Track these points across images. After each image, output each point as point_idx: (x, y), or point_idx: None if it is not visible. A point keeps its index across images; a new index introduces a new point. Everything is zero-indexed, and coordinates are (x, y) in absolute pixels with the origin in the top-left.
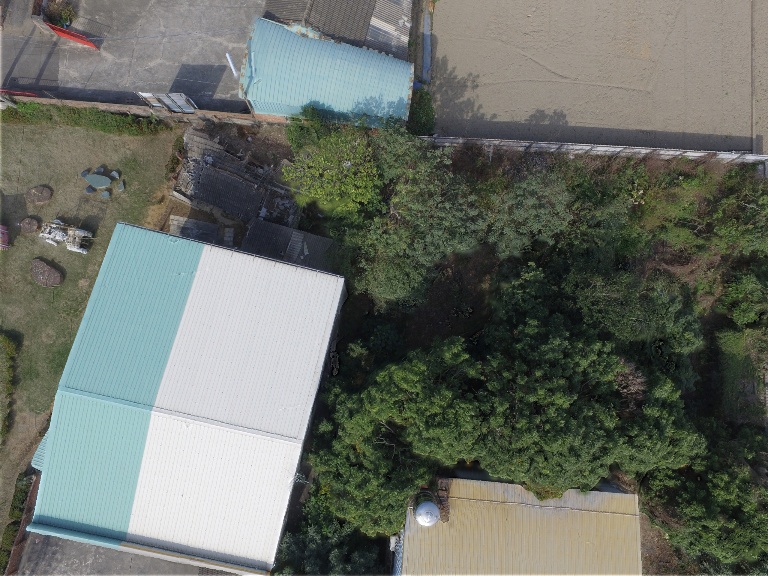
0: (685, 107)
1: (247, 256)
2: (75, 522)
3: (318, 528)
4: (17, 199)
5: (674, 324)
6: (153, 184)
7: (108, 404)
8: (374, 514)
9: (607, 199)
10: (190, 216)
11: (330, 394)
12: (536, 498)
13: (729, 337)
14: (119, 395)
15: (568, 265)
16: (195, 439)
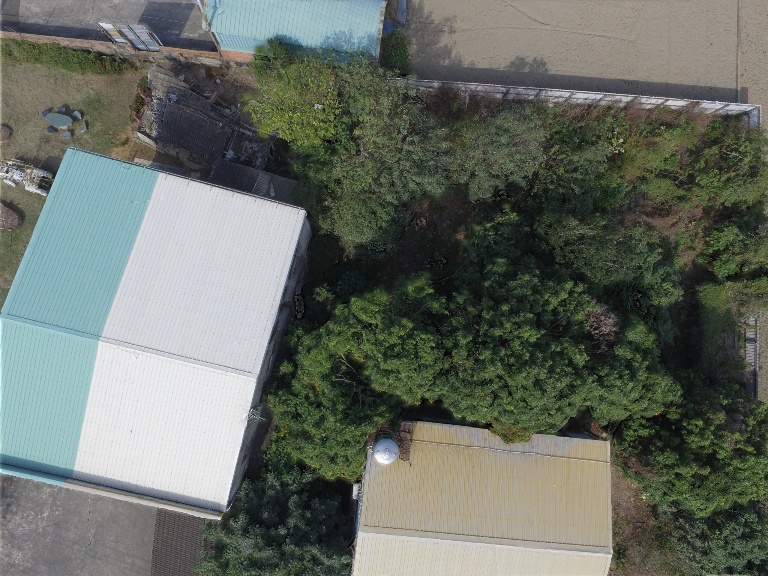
0: (668, 57)
1: (204, 185)
2: (18, 458)
3: (278, 474)
4: None
5: (652, 274)
6: (117, 125)
7: (53, 333)
8: (330, 450)
9: (585, 145)
10: (155, 159)
11: (293, 336)
12: (503, 443)
13: (709, 290)
14: (65, 324)
15: (543, 209)
16: (145, 371)
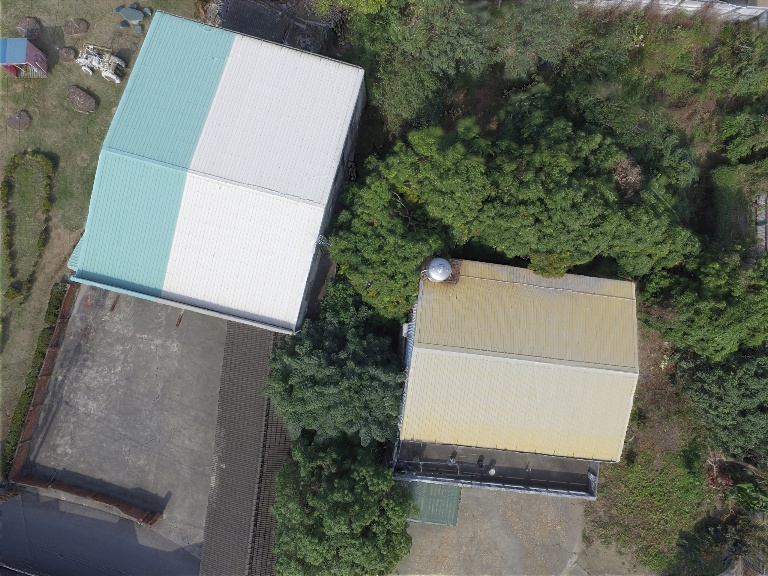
0: None
1: (275, 46)
2: (114, 278)
3: (336, 314)
4: (56, 31)
5: (671, 153)
6: None
7: (148, 164)
8: (391, 267)
9: (609, 37)
10: None
11: (348, 193)
12: (540, 280)
13: (723, 170)
14: (158, 157)
15: (572, 87)
16: (226, 201)
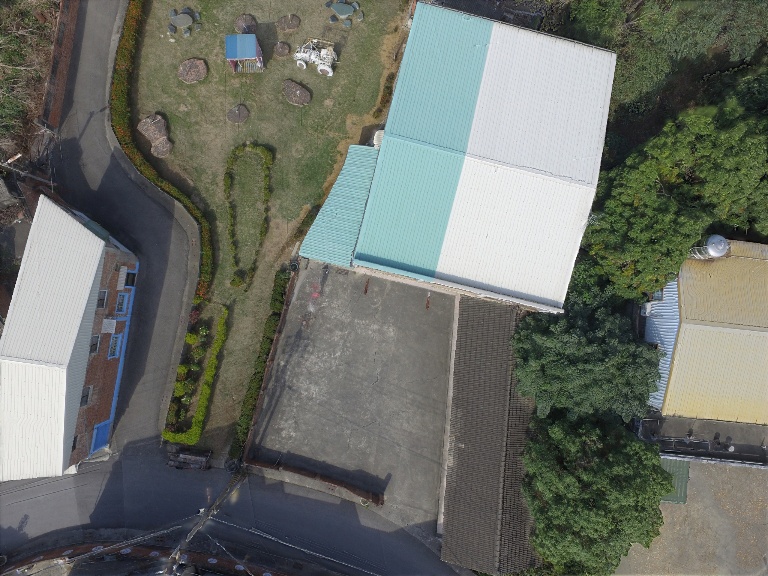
0: None
1: (531, 33)
2: (391, 260)
3: (579, 295)
4: (269, 27)
5: None
6: (388, 15)
7: (428, 148)
8: (670, 244)
9: None
10: None
11: None
12: None
13: None
14: (436, 142)
15: None
16: (501, 183)
